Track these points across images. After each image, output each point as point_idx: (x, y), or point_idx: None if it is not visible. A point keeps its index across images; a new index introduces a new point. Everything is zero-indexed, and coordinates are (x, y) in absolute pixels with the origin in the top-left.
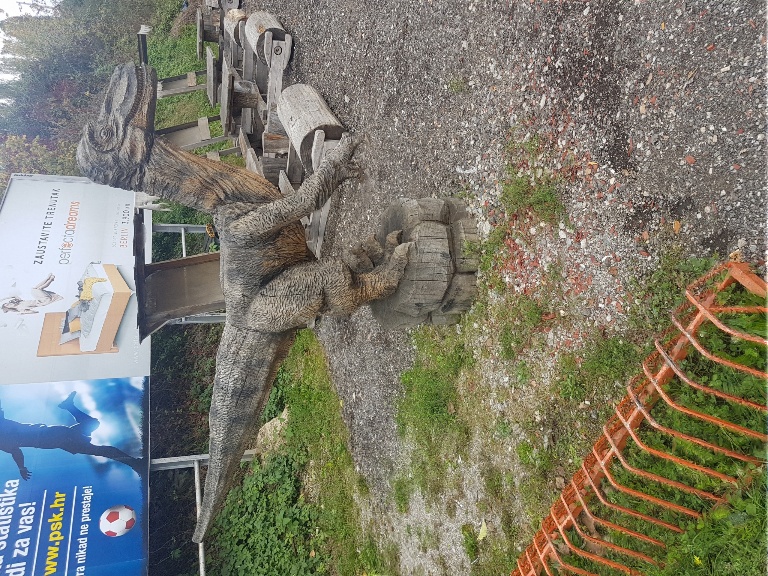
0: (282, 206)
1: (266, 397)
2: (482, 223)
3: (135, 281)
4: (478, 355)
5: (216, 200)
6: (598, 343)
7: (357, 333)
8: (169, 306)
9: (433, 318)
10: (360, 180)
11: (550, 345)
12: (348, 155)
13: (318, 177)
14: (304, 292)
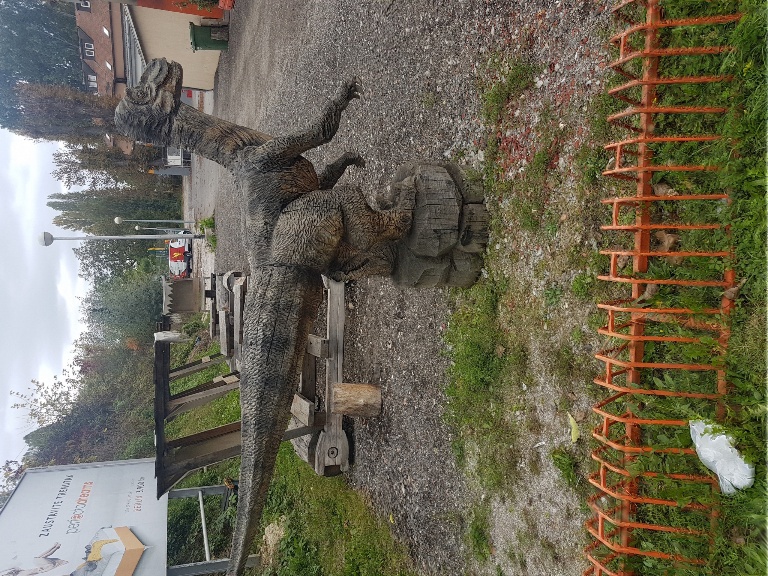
0: (293, 134)
1: (299, 364)
2: (476, 156)
3: (154, 417)
4: (509, 270)
5: (235, 146)
6: (599, 110)
7: (393, 415)
8: (189, 455)
9: (456, 263)
10: (361, 163)
11: (563, 168)
12: (345, 96)
13: (322, 113)
14: (323, 205)
